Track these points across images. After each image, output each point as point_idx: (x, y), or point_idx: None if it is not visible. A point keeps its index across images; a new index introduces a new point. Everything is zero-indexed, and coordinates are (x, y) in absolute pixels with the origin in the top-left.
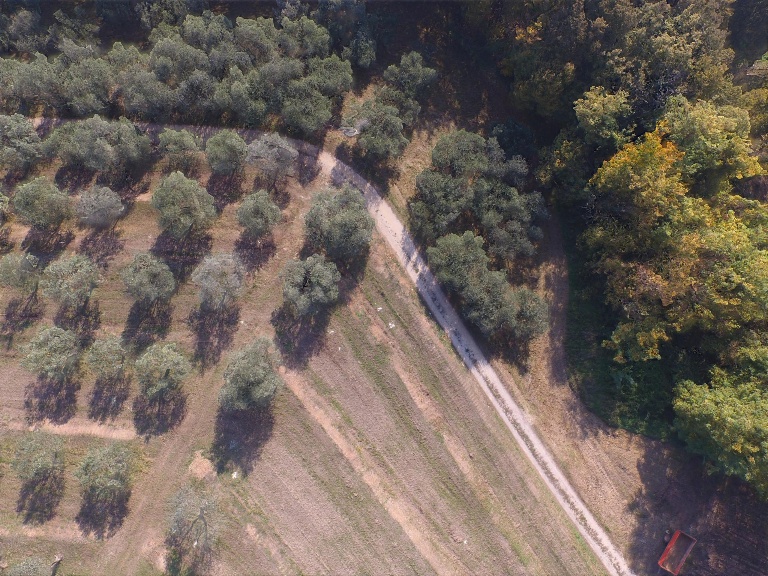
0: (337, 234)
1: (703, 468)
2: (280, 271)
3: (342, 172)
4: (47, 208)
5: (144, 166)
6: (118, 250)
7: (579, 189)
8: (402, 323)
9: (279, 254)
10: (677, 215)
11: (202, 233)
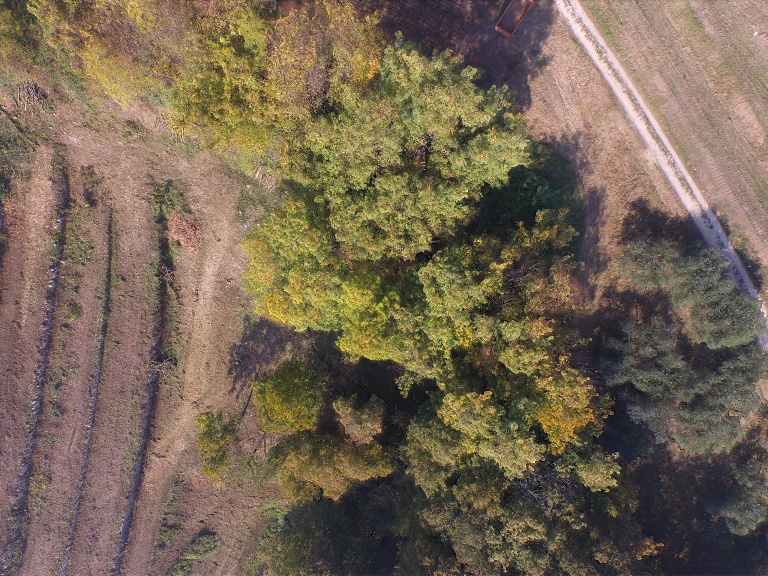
0: None
1: None
2: None
3: None
4: None
5: None
6: None
7: None
8: None
9: None
10: None
11: None
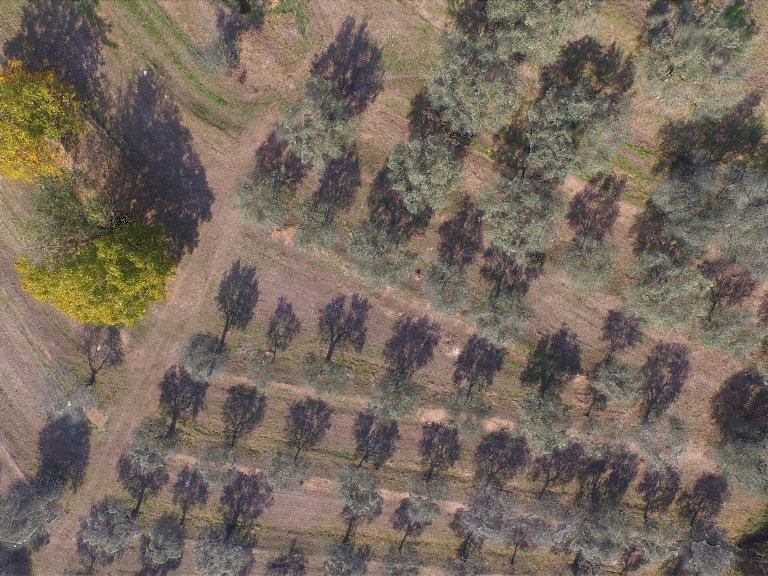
0: None
1: None
2: None
3: None
4: None
5: None
6: None
7: None
8: None
9: None
10: None
11: None
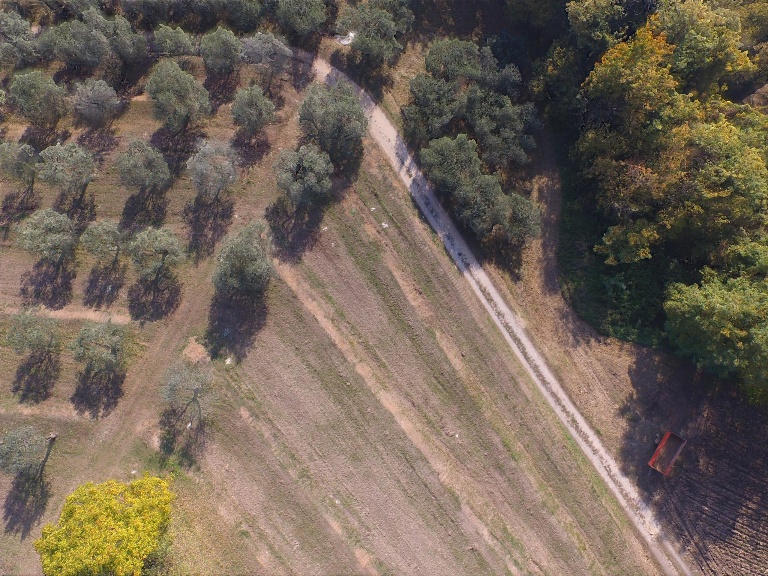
0: (330, 122)
1: (694, 374)
2: (274, 162)
3: (336, 79)
4: (43, 99)
5: (140, 70)
6: (114, 146)
7: (572, 98)
8: (395, 223)
9: (273, 153)
10: (667, 109)
11: (197, 131)
